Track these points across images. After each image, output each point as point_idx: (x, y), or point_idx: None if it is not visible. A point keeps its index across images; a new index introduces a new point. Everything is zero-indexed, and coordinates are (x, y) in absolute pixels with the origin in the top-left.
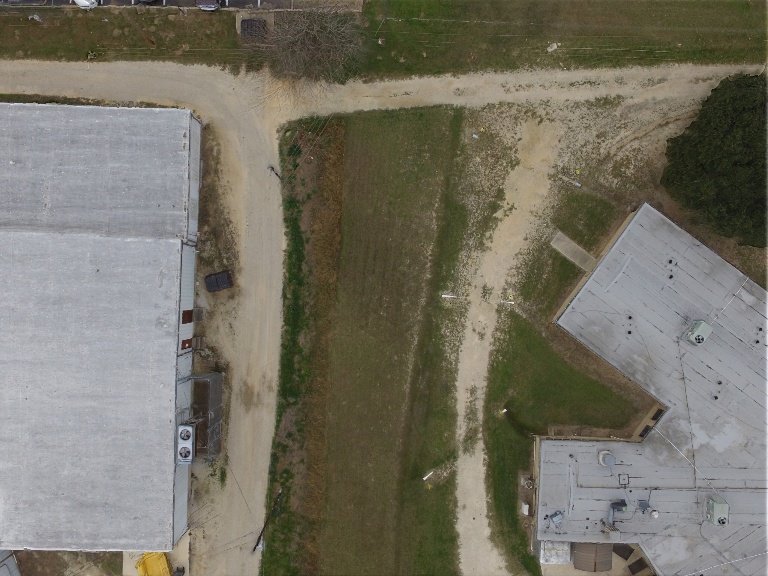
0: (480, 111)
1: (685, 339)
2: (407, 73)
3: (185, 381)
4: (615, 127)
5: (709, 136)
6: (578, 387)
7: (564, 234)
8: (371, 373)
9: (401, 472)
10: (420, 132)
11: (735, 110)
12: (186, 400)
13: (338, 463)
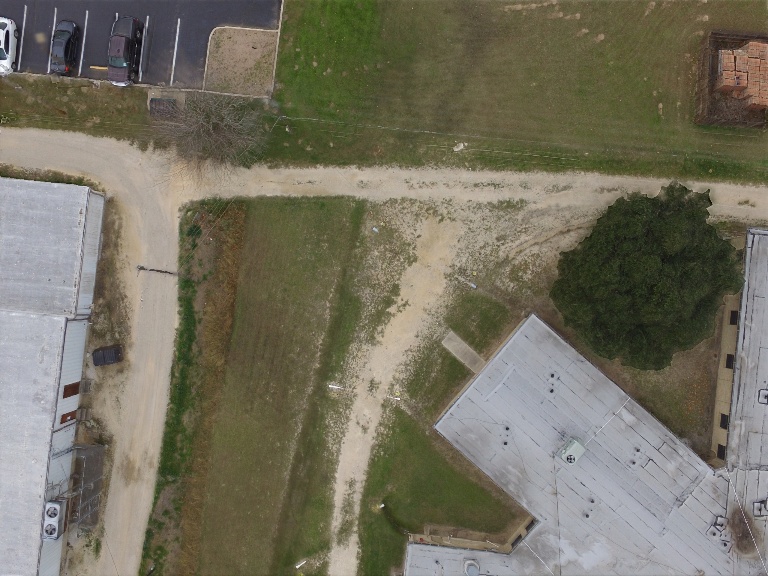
0: (382, 205)
1: (559, 456)
2: (312, 162)
3: (64, 453)
4: (516, 231)
5: (589, 262)
6: (457, 489)
7: (456, 334)
8: (252, 457)
9: (275, 558)
10: (320, 221)
11: (617, 238)
12: (63, 472)
13: (213, 544)
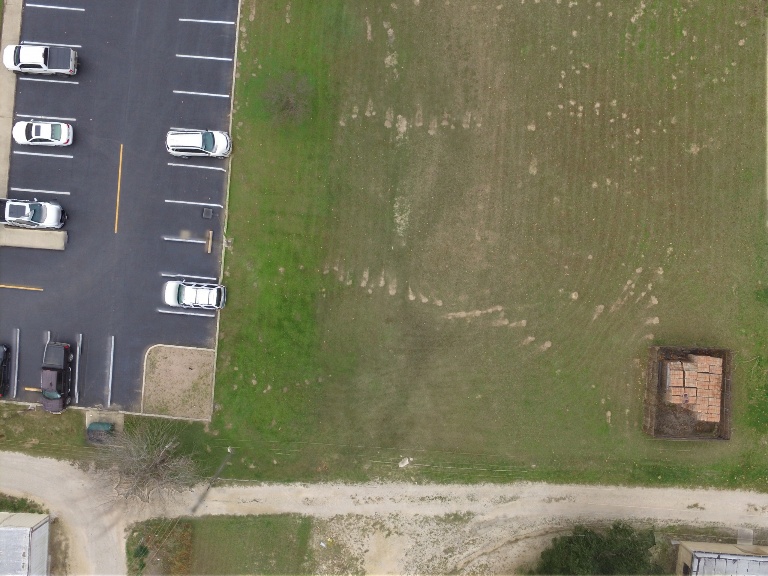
0: (328, 522)
1: None
2: None
3: None
4: (463, 543)
5: None
6: None
7: None
8: None
9: None
10: (267, 539)
11: None
12: None
13: None
